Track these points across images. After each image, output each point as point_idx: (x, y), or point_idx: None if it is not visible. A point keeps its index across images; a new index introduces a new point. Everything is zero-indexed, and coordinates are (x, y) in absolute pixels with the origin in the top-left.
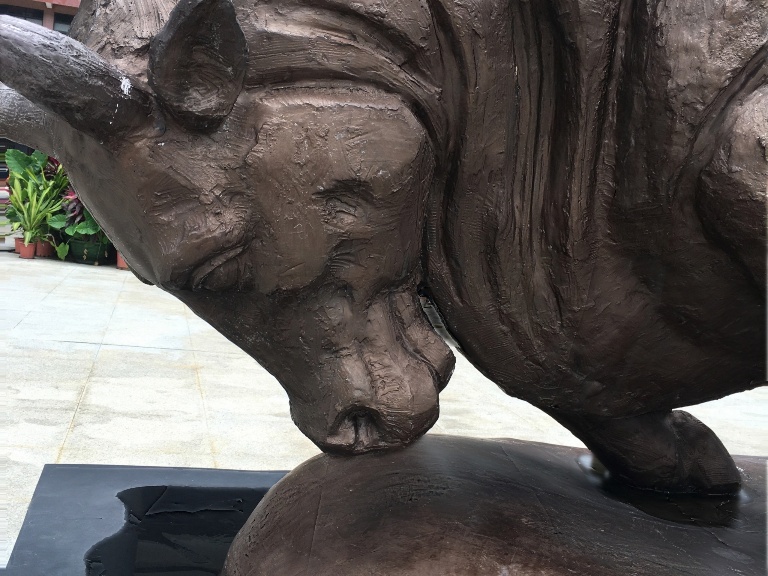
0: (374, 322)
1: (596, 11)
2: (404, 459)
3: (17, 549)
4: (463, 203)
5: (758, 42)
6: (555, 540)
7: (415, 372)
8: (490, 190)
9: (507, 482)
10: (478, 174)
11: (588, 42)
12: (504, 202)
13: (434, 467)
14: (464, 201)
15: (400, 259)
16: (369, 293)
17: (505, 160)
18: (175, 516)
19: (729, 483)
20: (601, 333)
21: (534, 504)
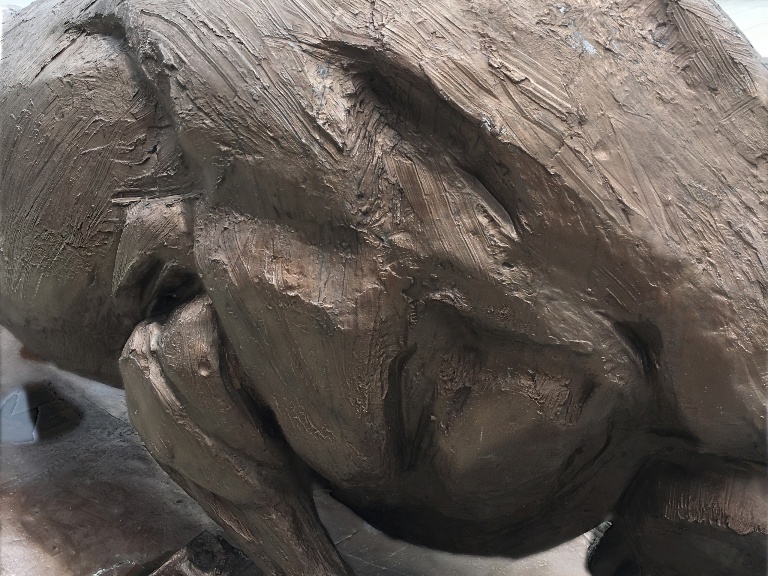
0: None
1: None
2: None
3: None
4: None
5: None
6: None
7: None
8: None
9: None
10: None
11: None
12: None
13: None
14: None
15: None
16: None
17: None
18: None
19: None
20: None
21: (506, 574)
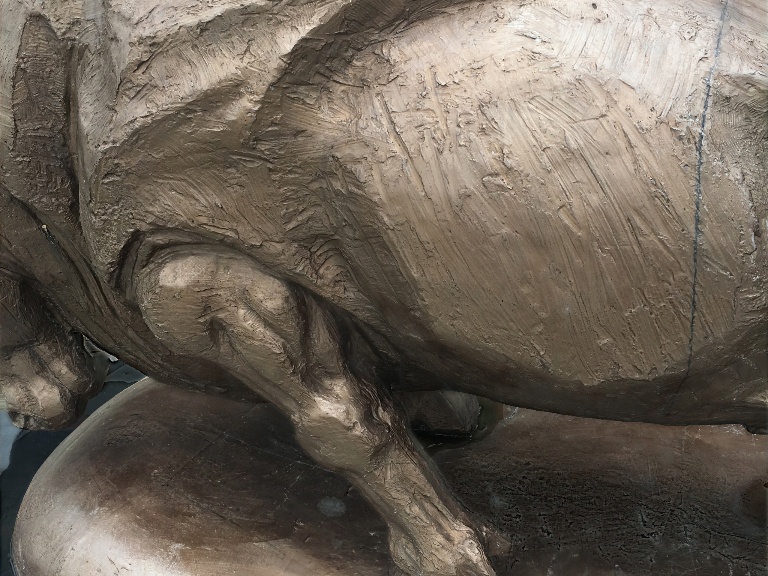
0: (17, 366)
1: (48, 209)
2: (159, 400)
3: (2, 408)
4: (59, 296)
5: (118, 247)
6: (154, 492)
7: (48, 394)
8: (70, 290)
9: (200, 430)
10: (54, 283)
11: (57, 224)
12: (80, 297)
13: (163, 412)
14: (58, 295)
15: (15, 336)
16: (3, 354)
17: (66, 276)
18: (113, 386)
19: (449, 429)
20: (190, 367)
21: (186, 456)
